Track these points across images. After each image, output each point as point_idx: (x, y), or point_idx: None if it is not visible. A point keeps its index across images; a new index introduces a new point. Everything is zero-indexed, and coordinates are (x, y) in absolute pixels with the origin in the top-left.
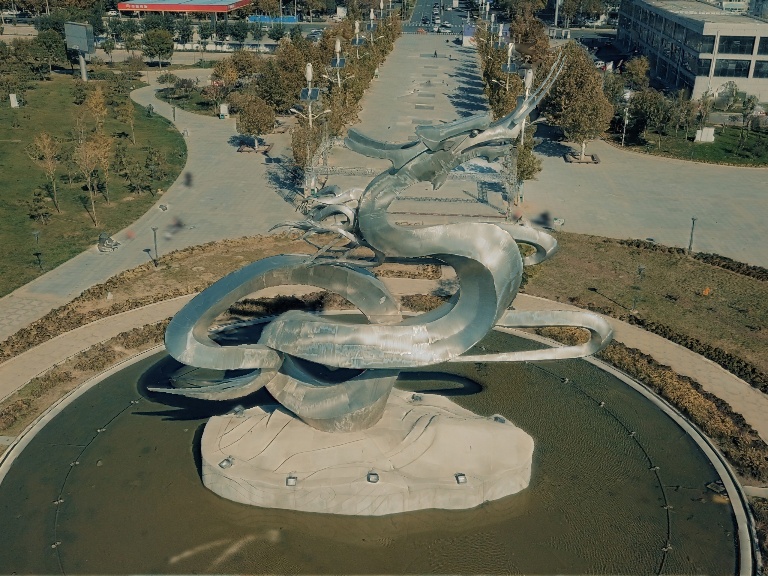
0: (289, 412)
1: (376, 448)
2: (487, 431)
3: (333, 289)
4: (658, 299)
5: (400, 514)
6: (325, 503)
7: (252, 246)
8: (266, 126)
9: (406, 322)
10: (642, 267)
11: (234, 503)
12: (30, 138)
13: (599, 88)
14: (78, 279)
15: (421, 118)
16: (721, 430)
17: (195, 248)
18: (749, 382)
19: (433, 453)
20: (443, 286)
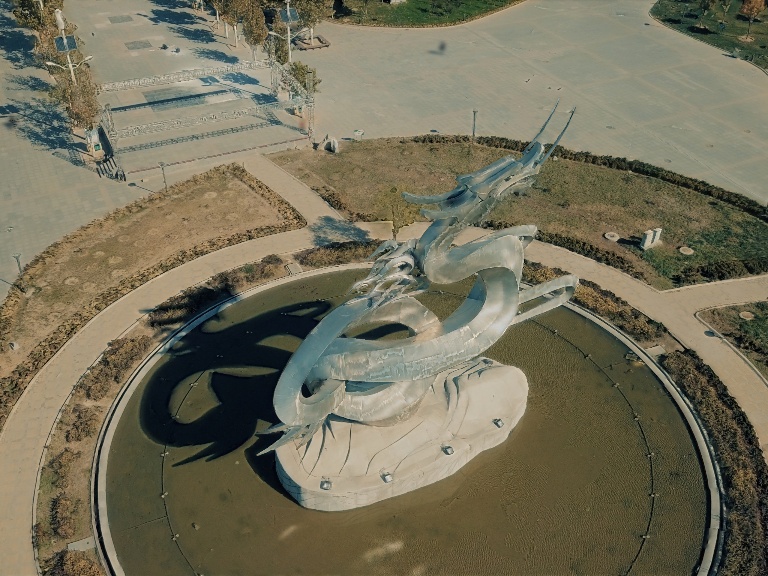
0: (344, 420)
1: (434, 425)
2: (500, 379)
3: (389, 319)
4: None
5: (465, 466)
6: (416, 483)
7: (99, 236)
8: None
9: (449, 326)
10: None
11: (342, 512)
12: None
13: None
14: None
15: (116, 14)
16: (609, 309)
17: (44, 256)
18: (595, 259)
19: (472, 411)
20: (317, 232)
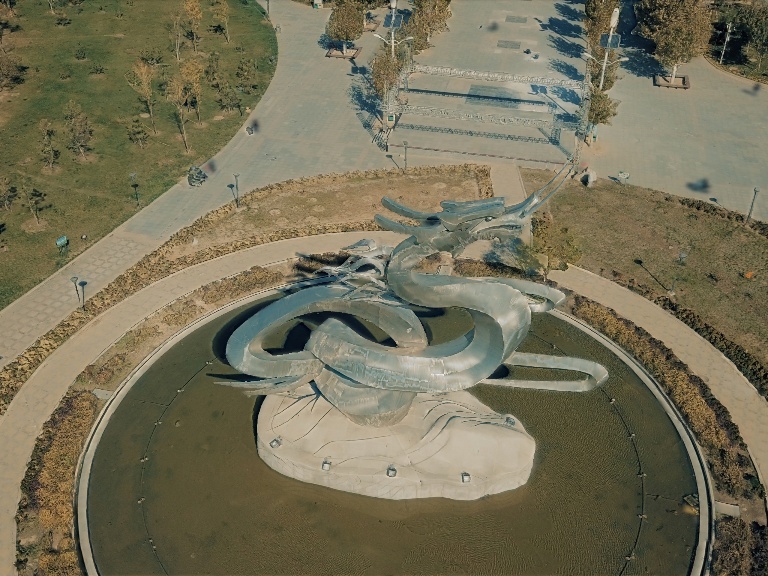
0: None
1: (398, 445)
2: (494, 438)
3: (367, 318)
4: (700, 279)
5: (413, 500)
6: (352, 486)
7: (326, 186)
8: (354, 32)
9: (427, 352)
10: (683, 256)
11: (281, 475)
12: (132, 32)
13: (702, 2)
14: (169, 218)
15: (516, 14)
16: (712, 442)
17: (274, 187)
18: (757, 388)
19: (446, 453)
20: (496, 249)
